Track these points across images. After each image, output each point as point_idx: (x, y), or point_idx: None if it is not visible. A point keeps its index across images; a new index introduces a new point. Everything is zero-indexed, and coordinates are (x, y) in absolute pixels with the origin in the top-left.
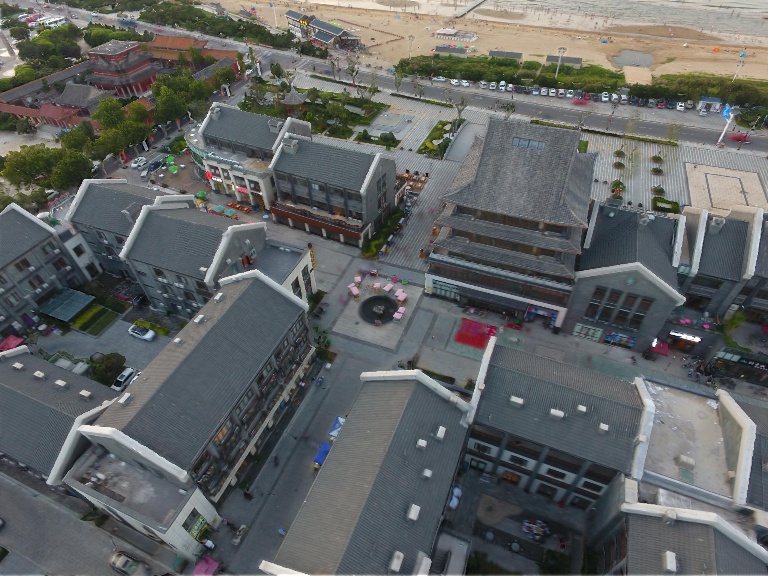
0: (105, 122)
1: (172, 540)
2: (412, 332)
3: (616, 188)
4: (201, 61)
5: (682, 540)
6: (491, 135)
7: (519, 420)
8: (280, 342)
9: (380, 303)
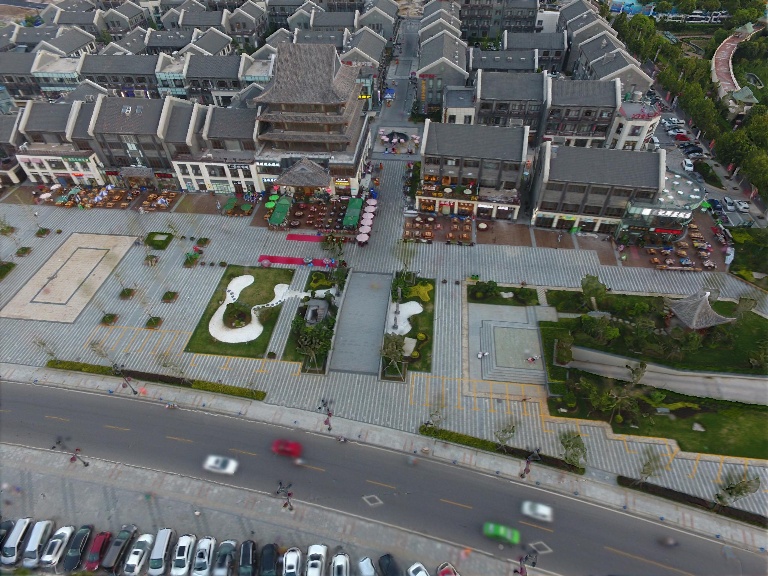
0: None
1: None
2: (373, 133)
3: (196, 256)
4: None
5: None
6: None
7: None
8: None
9: None
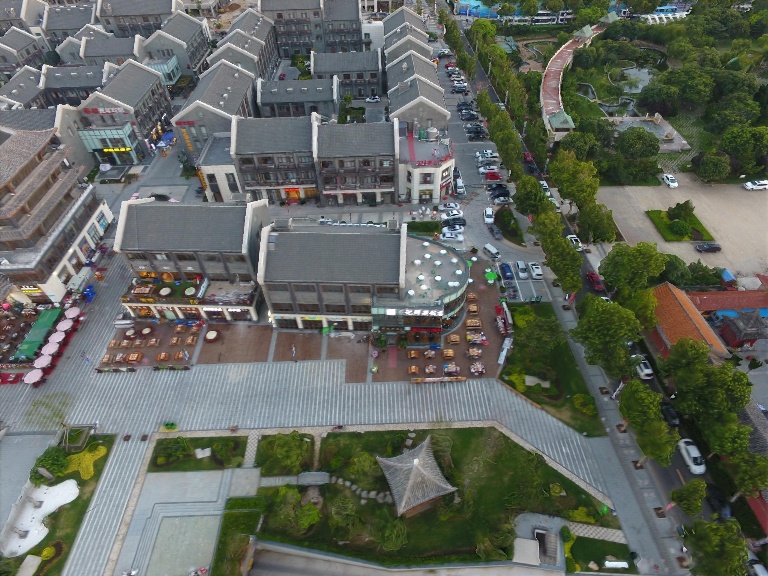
0: None
1: None
2: (128, 198)
3: None
4: None
5: None
6: None
7: None
8: None
9: None
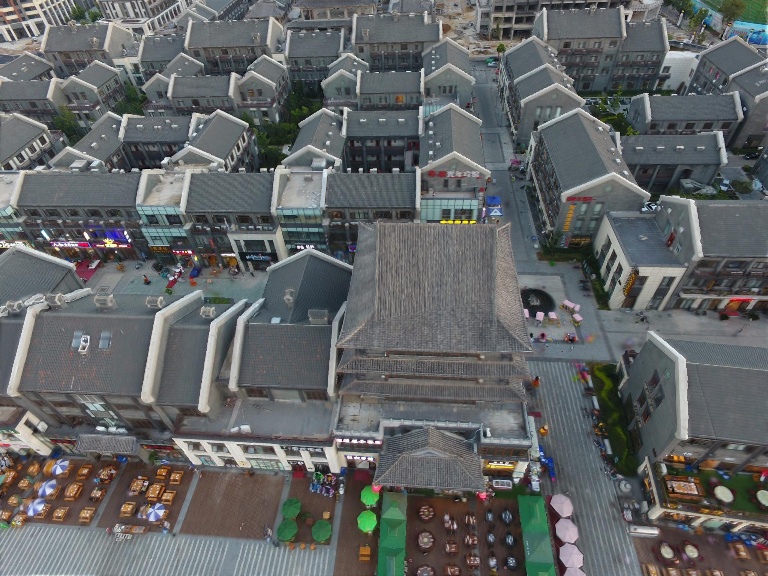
0: None
1: None
2: None
3: None
4: None
5: (321, 149)
6: None
7: None
8: None
9: (538, 310)
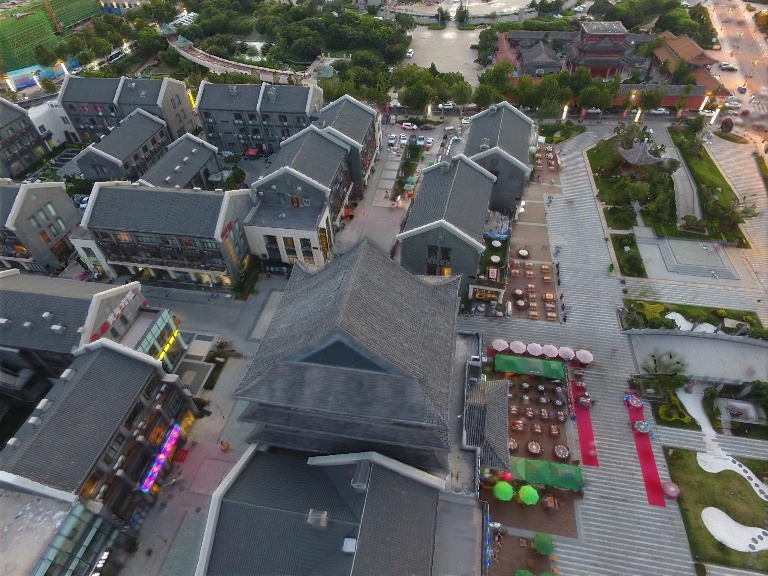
0: (486, 79)
1: (75, 247)
2: None
3: None
4: (682, 78)
5: None
6: (351, 253)
7: (59, 384)
8: (184, 235)
9: None
